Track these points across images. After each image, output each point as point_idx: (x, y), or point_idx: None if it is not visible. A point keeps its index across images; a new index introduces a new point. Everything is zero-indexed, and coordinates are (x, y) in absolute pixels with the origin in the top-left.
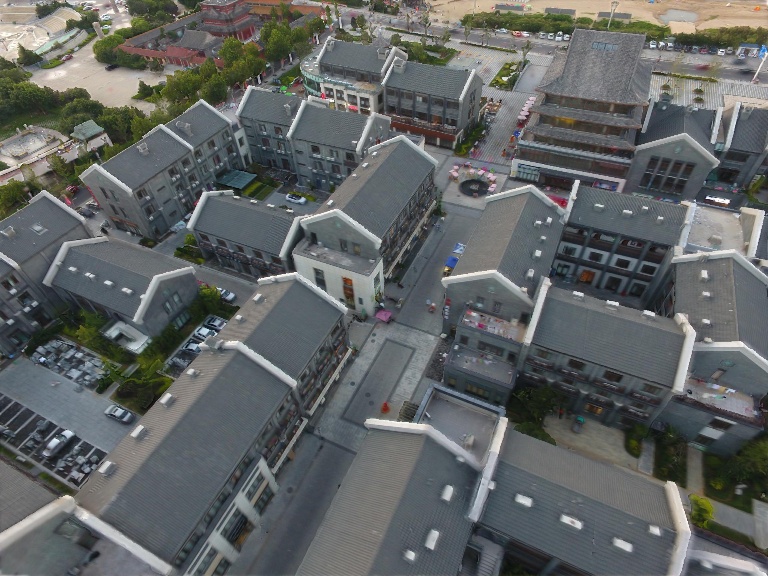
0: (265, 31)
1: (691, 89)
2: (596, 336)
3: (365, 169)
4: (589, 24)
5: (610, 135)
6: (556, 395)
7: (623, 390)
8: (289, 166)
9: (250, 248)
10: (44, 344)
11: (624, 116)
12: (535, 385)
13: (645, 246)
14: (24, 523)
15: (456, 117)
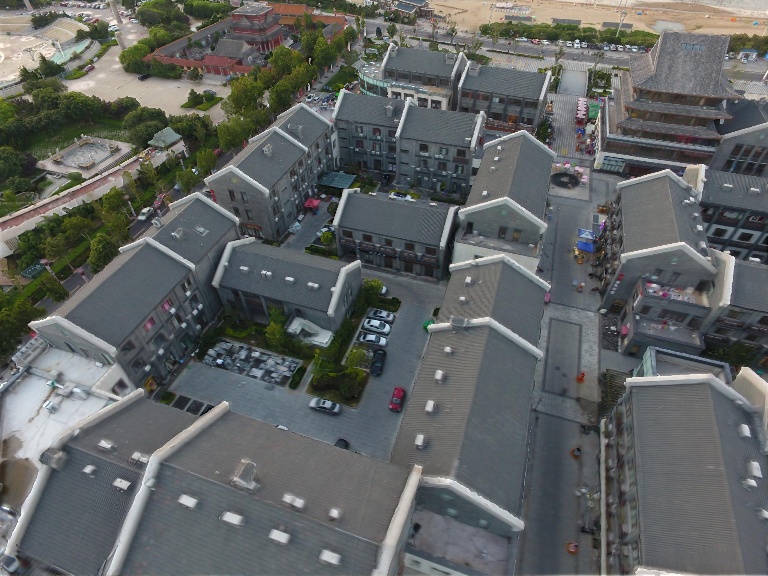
0: (307, 39)
1: None
2: None
3: (498, 162)
4: None
5: (697, 126)
6: (750, 350)
7: None
8: (381, 166)
9: (403, 241)
10: (212, 347)
11: (713, 109)
12: (718, 345)
13: None
14: (410, 489)
15: (533, 116)
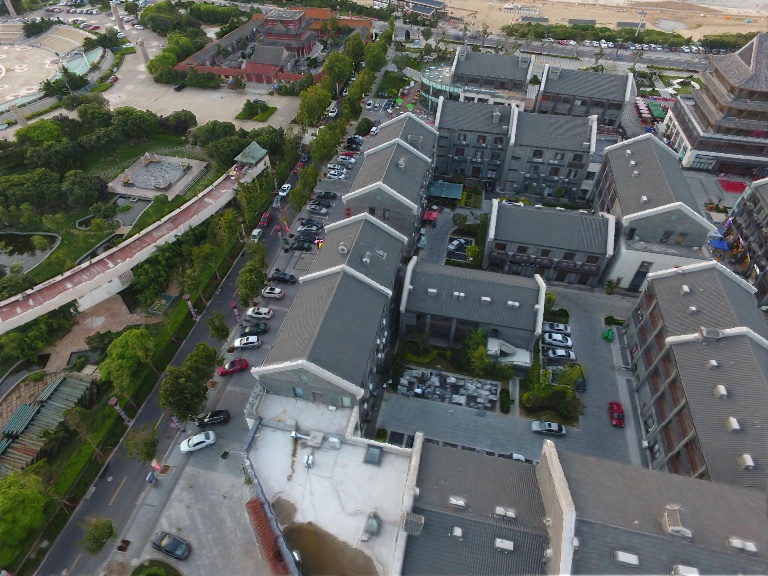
0: (352, 45)
1: None
2: None
3: (635, 166)
4: None
5: None
6: None
7: None
8: (479, 174)
9: (564, 251)
10: (401, 376)
11: None
12: None
13: None
14: None
15: (616, 117)
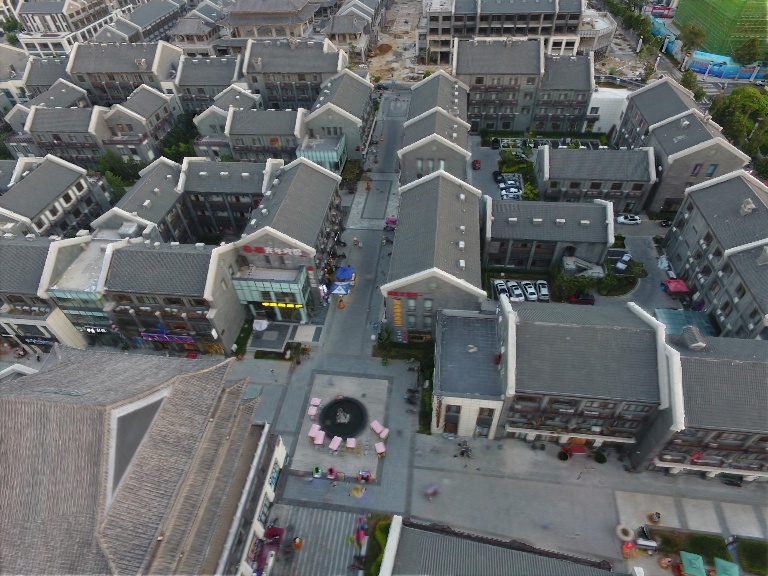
0: None
1: None
2: None
3: None
4: None
5: None
6: None
7: None
8: None
9: None
10: None
11: None
12: None
13: None
14: (455, 59)
15: None
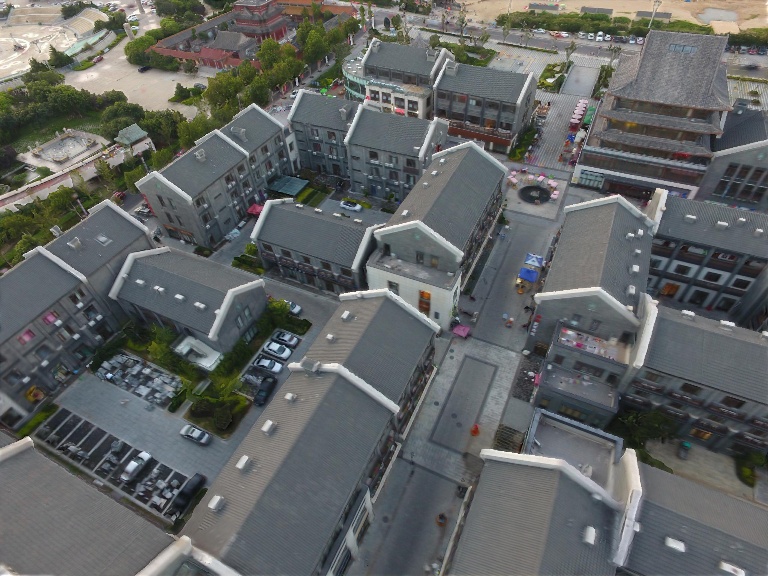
0: (301, 32)
1: (745, 91)
2: (715, 359)
3: (435, 177)
4: (627, 24)
5: (685, 141)
6: (667, 420)
7: (743, 416)
8: (340, 171)
9: (318, 259)
10: (109, 359)
11: (702, 121)
12: (638, 408)
13: (741, 259)
14: (149, 570)
15: (511, 121)
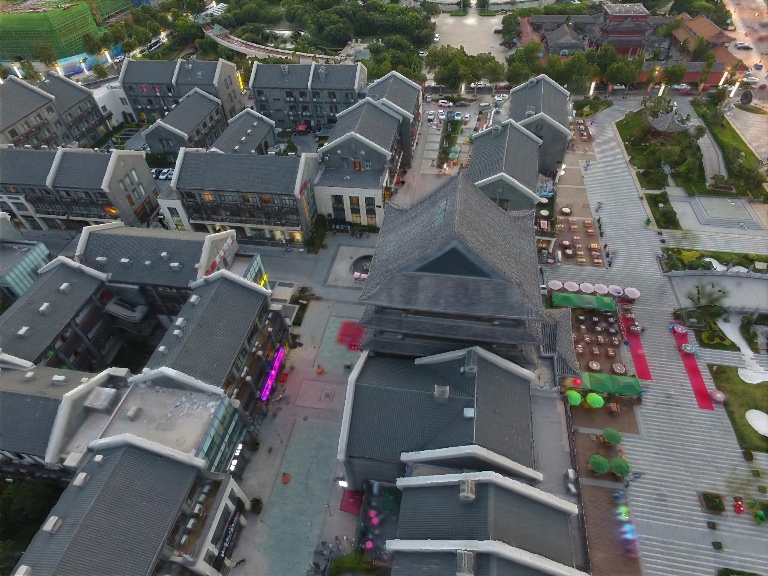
0: (590, 52)
1: None
2: None
3: None
4: None
5: None
6: None
7: None
8: None
9: None
10: None
11: None
12: None
13: None
14: None
15: None
